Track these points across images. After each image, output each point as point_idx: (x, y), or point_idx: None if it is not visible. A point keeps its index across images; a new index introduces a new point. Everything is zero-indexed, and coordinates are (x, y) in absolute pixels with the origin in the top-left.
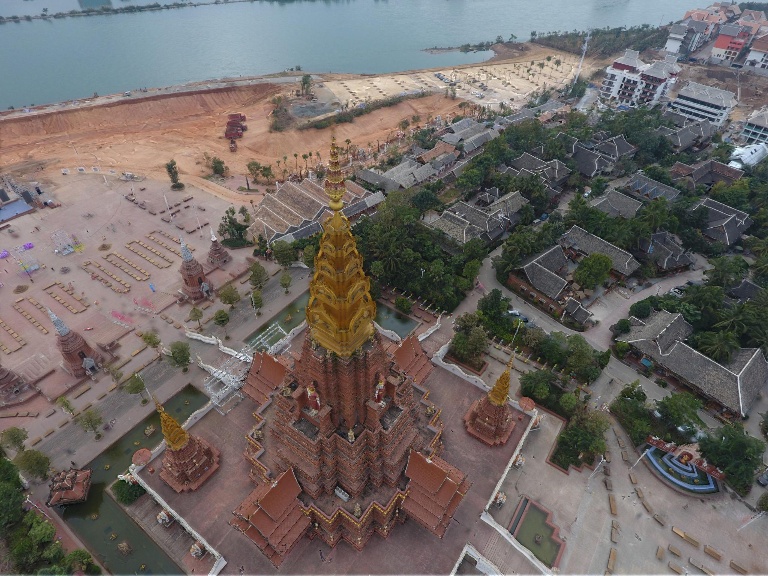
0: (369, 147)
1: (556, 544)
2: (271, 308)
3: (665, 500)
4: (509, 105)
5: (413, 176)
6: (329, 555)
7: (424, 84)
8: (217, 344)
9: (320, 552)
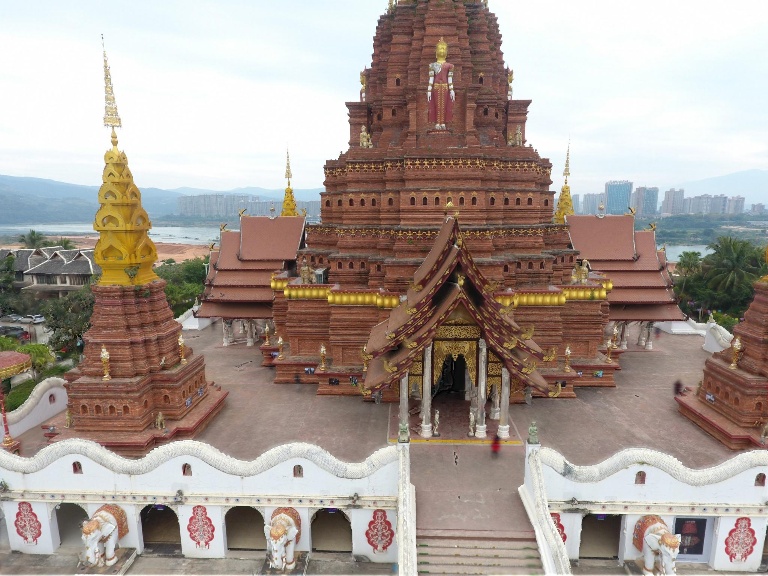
0: None
1: None
2: None
3: None
4: None
5: None
6: (249, 367)
7: None
8: None
9: (249, 361)
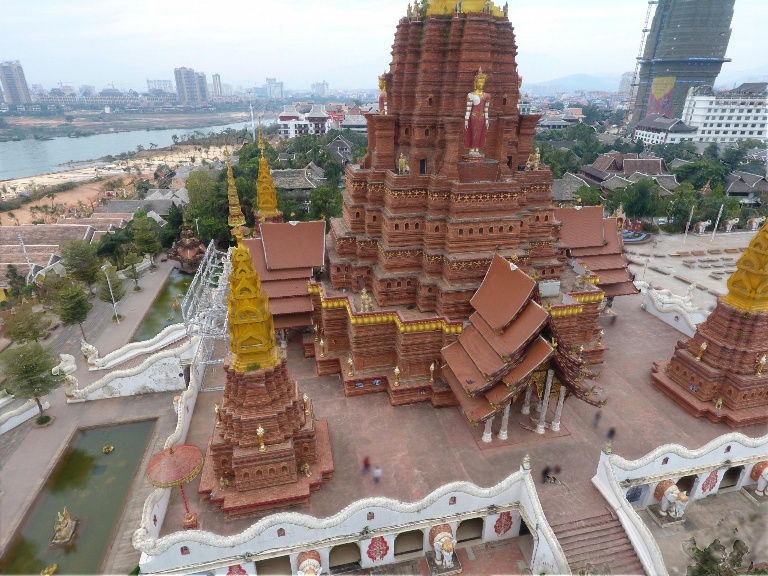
0: (80, 207)
1: None
2: (131, 308)
3: (643, 249)
4: (209, 162)
5: (177, 198)
6: (591, 386)
7: (91, 174)
8: (76, 369)
9: None
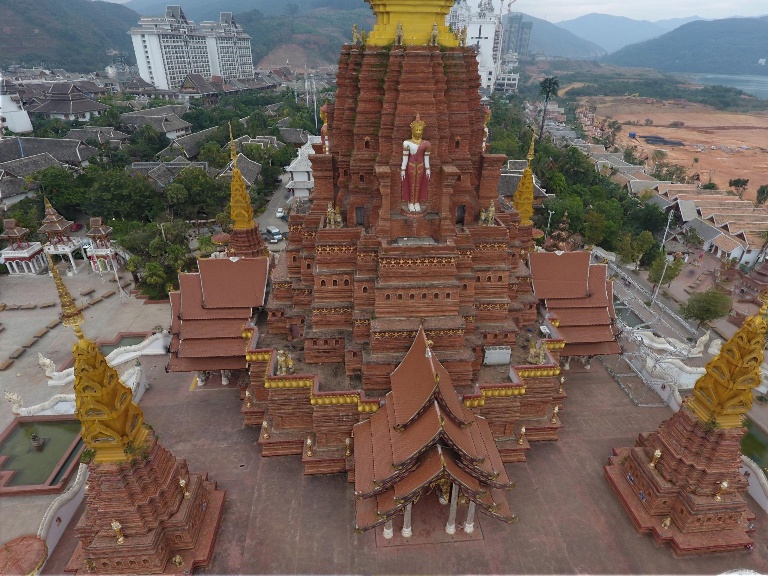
0: None
1: (1, 455)
2: None
3: None
4: None
5: None
6: None
7: None
8: None
9: None
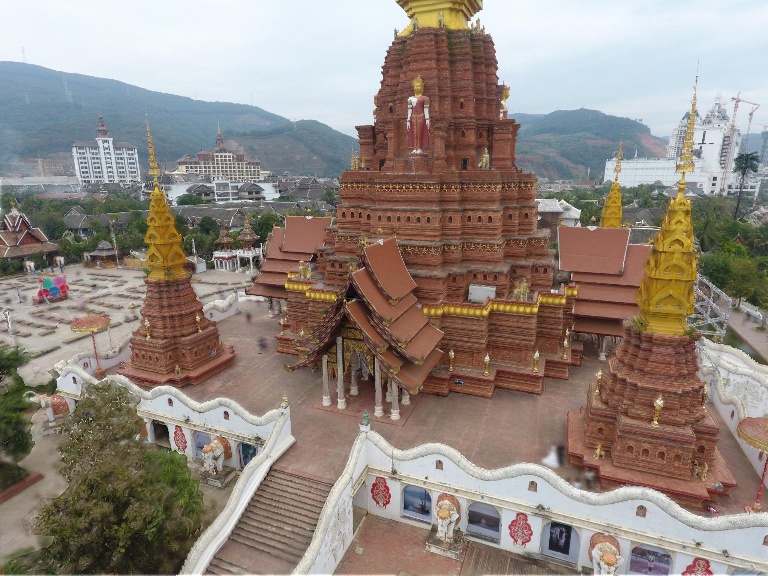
0: None
1: None
2: None
3: None
4: None
5: None
6: None
7: None
8: None
9: None
